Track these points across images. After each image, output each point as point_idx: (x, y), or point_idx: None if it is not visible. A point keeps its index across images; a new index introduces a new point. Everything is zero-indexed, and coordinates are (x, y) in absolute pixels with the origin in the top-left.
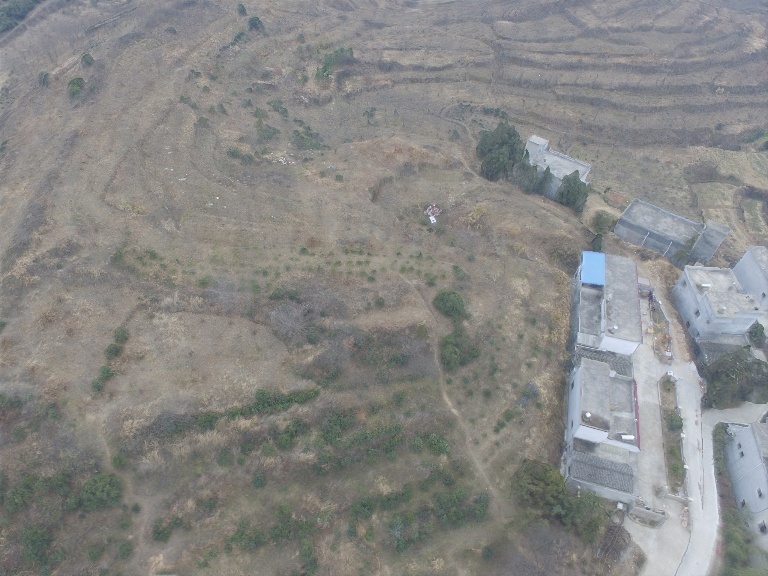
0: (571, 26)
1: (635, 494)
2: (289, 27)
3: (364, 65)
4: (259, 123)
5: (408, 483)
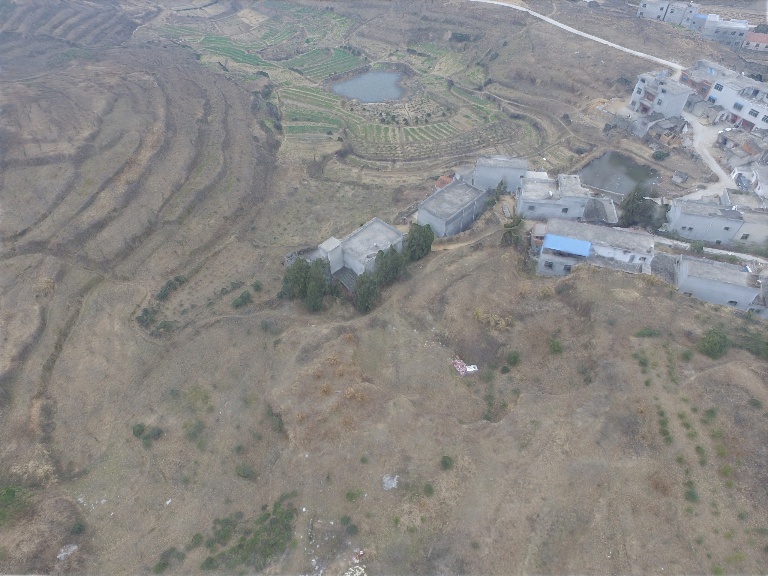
0: (49, 168)
1: None
2: None
3: None
4: None
5: None
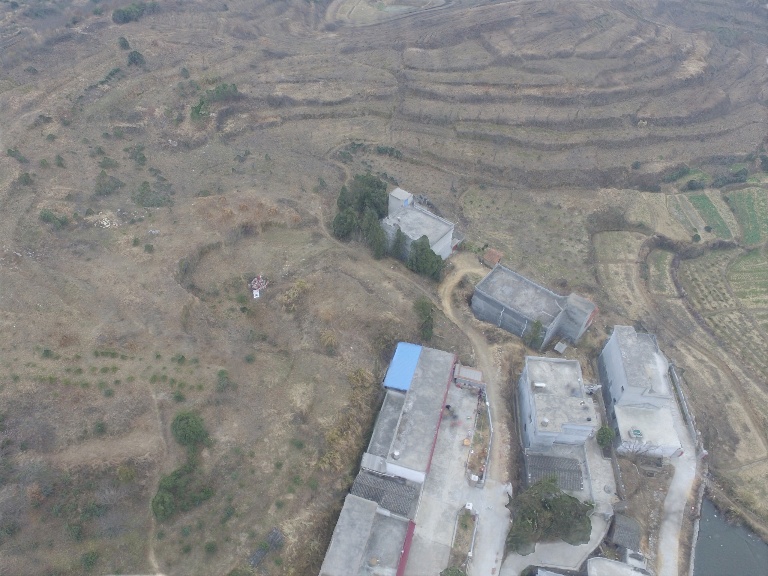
0: (484, 53)
1: None
2: (175, 60)
3: (252, 101)
4: (101, 175)
5: None
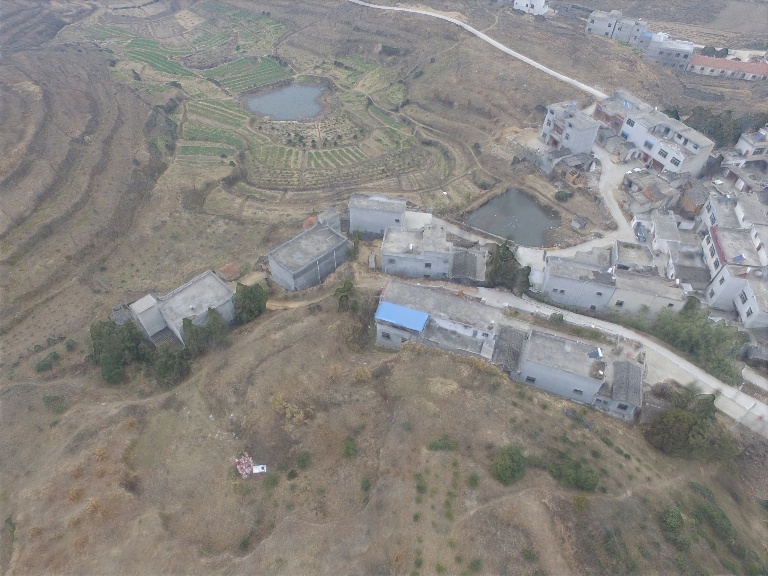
0: None
1: (640, 366)
2: None
3: None
4: None
5: (720, 561)
